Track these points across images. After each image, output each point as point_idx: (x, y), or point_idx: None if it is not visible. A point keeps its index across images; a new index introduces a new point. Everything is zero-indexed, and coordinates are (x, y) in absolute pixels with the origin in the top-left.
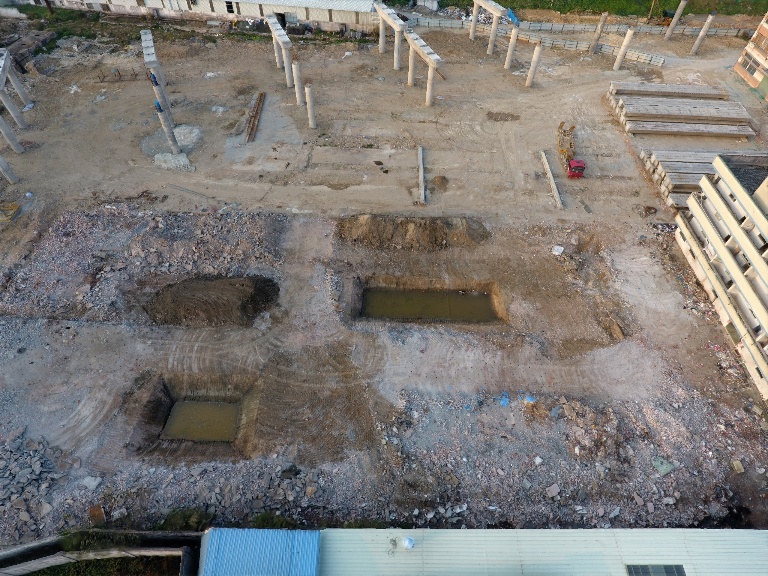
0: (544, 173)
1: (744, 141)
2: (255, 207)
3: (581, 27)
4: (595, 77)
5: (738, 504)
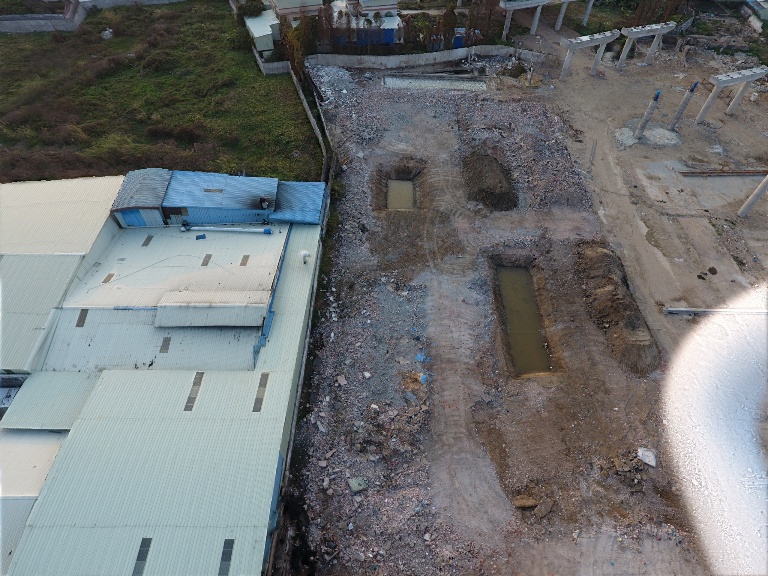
0: None
1: None
2: (593, 188)
3: None
4: None
5: (318, 567)
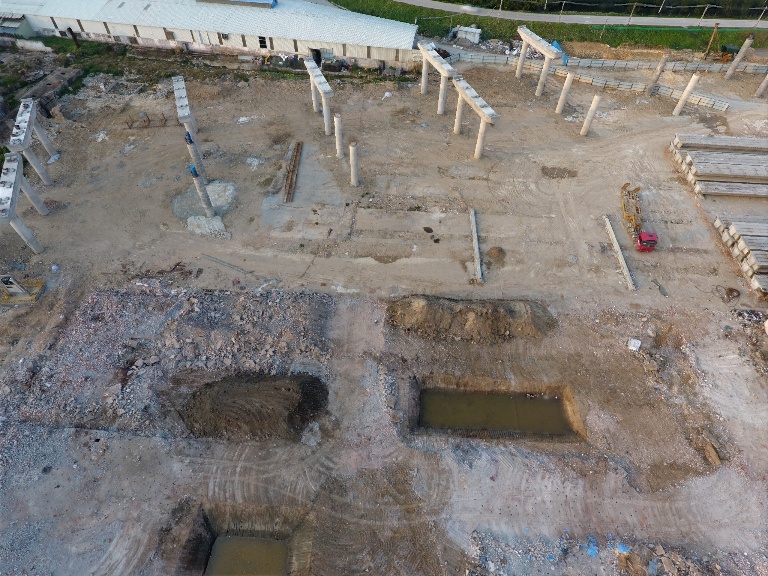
0: (610, 244)
1: None
2: (297, 284)
3: (634, 64)
4: (654, 124)
5: None
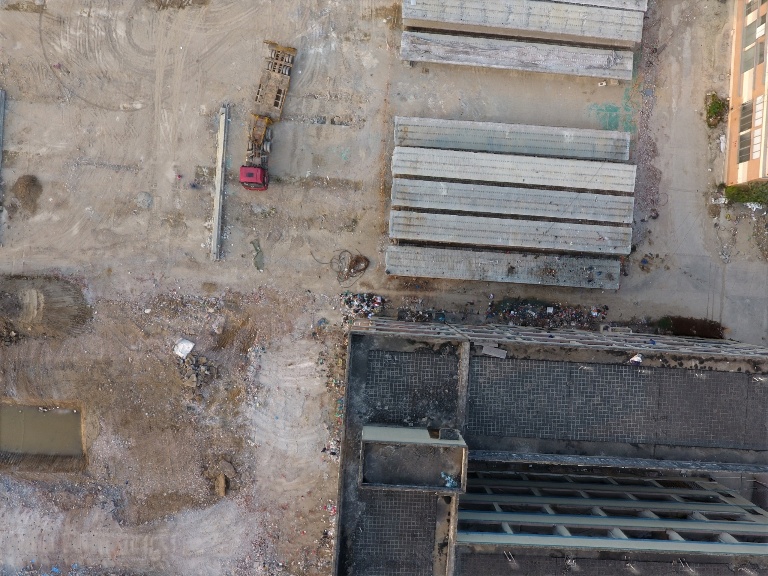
0: (212, 170)
1: (612, 84)
2: None
3: None
4: None
5: None
